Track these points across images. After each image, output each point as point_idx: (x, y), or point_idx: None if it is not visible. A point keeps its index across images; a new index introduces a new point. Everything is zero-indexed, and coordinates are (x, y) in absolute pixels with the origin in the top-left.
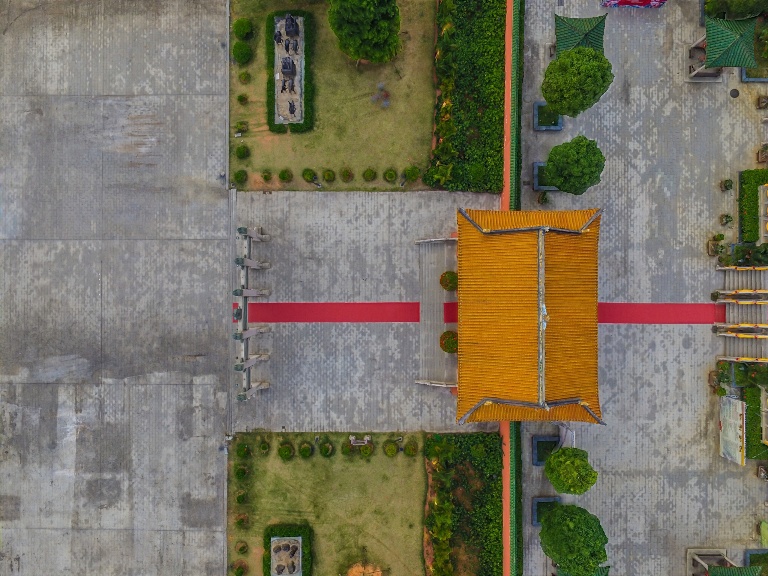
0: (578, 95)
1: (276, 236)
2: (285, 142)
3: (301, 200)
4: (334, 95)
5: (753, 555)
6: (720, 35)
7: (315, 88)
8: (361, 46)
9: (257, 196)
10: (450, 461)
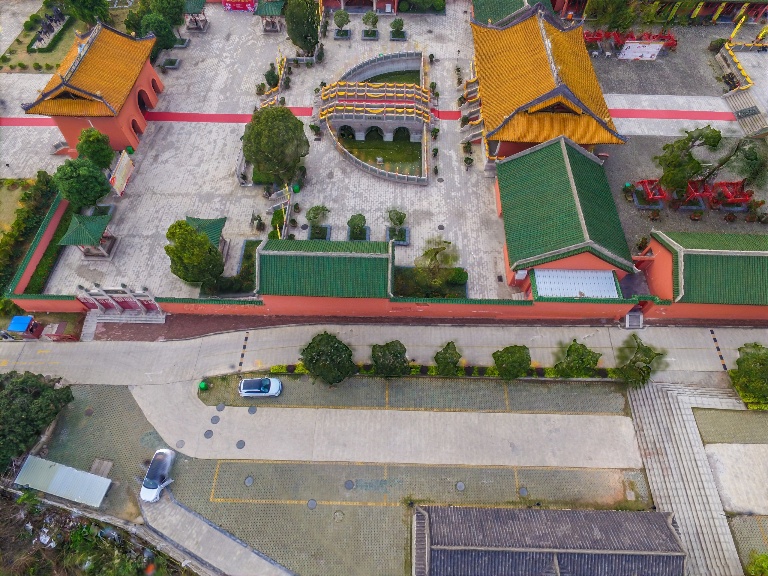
0: (158, 1)
1: (2, 90)
2: (33, 56)
3: (27, 77)
4: (71, 41)
5: (249, 241)
6: None
7: (62, 38)
8: (74, 4)
9: (2, 75)
10: (41, 177)
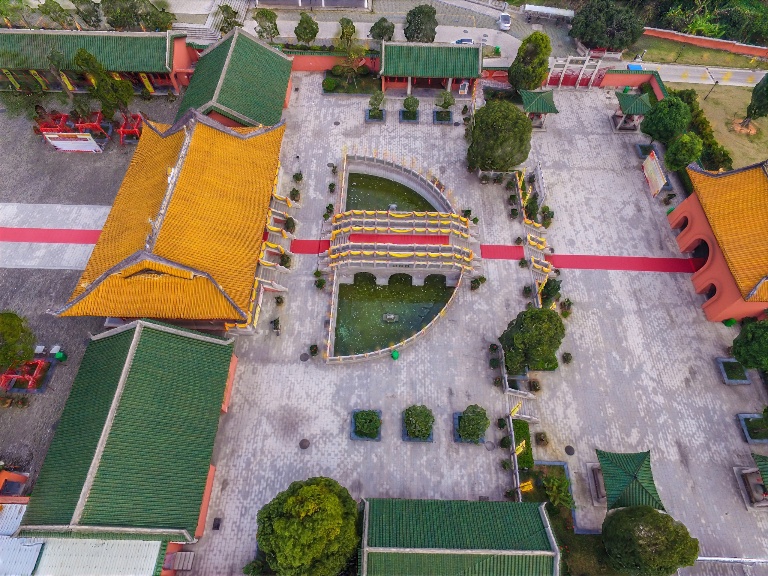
0: None
1: None
2: None
3: None
4: None
5: None
6: (648, 485)
7: None
8: None
9: None
10: None
